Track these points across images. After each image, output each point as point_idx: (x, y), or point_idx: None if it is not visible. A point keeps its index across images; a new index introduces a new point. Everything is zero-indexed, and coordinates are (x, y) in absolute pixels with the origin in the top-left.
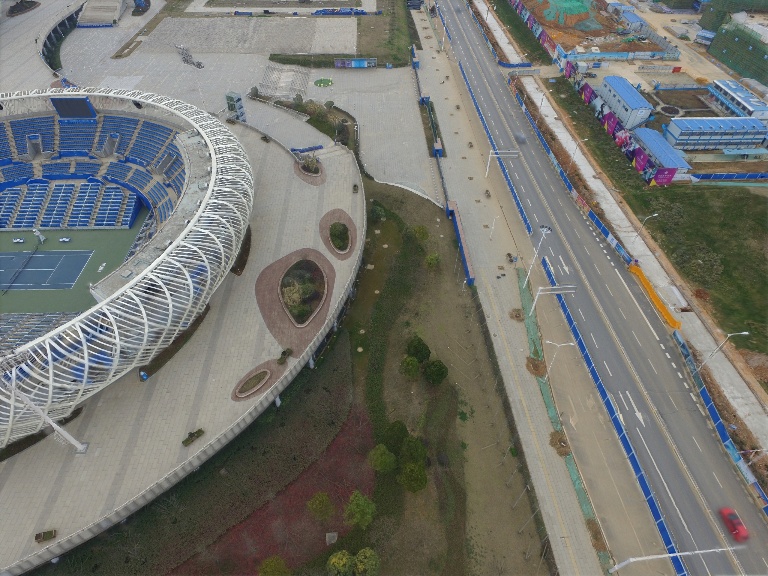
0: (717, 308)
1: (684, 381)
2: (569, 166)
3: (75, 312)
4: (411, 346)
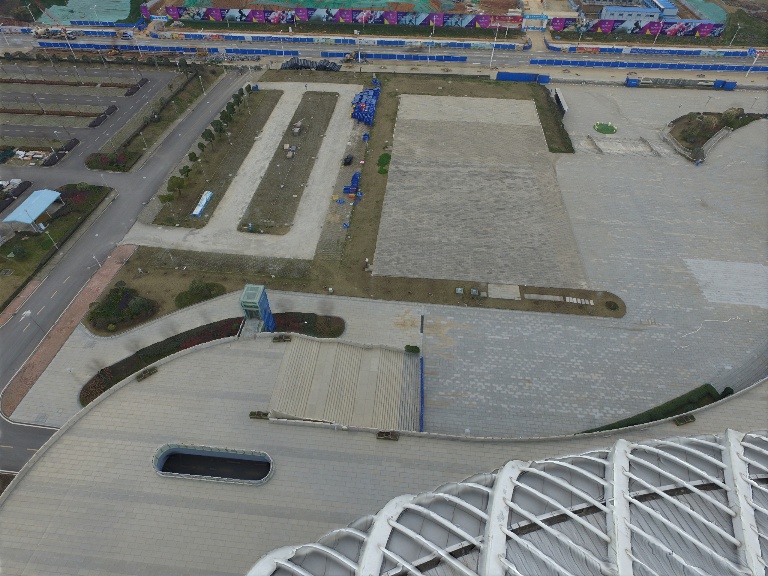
0: None
1: None
2: None
3: None
4: None
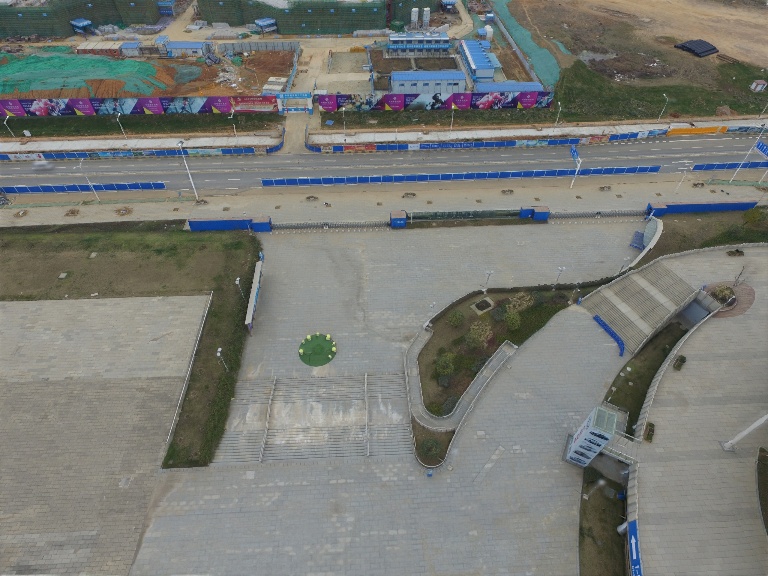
0: (685, 113)
1: (761, 137)
2: (533, 138)
3: None
4: None
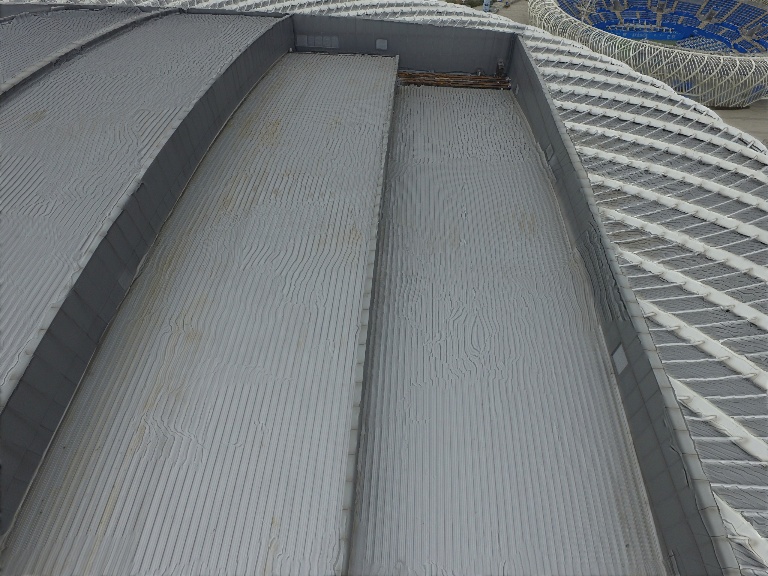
0: None
1: None
2: None
3: (677, 43)
4: None
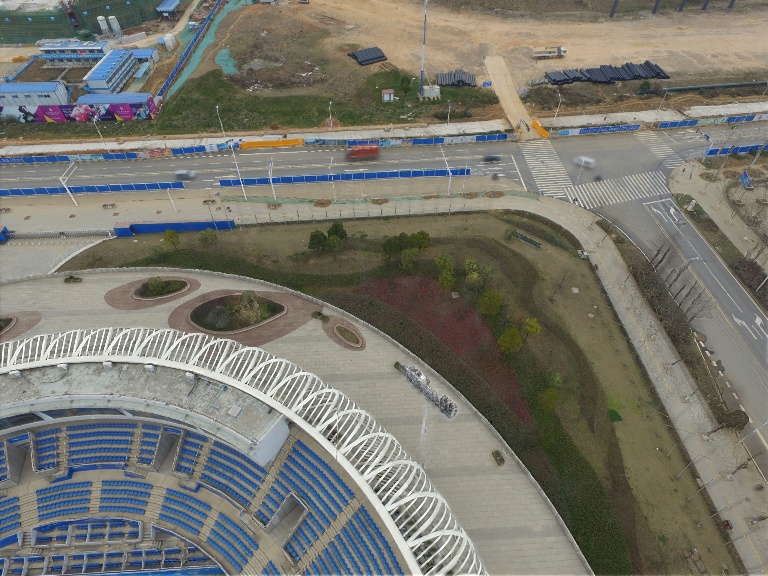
0: (287, 125)
1: (339, 150)
2: (97, 152)
3: None
4: (319, 237)
